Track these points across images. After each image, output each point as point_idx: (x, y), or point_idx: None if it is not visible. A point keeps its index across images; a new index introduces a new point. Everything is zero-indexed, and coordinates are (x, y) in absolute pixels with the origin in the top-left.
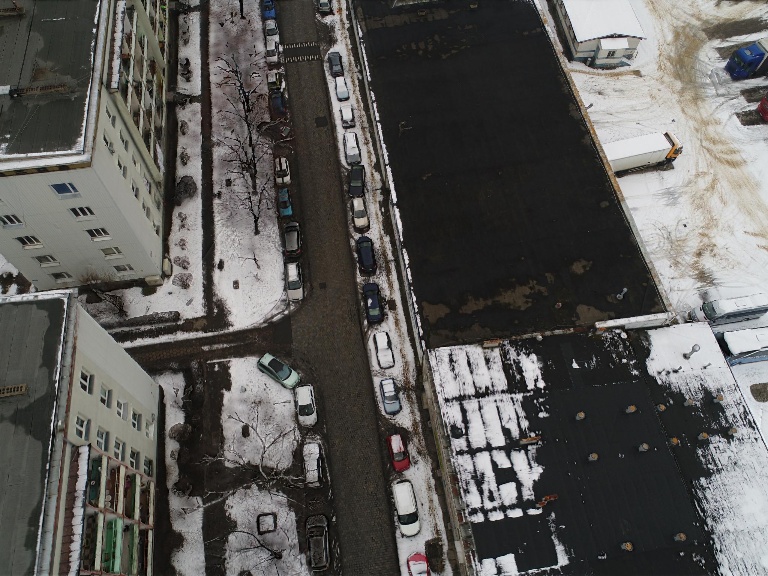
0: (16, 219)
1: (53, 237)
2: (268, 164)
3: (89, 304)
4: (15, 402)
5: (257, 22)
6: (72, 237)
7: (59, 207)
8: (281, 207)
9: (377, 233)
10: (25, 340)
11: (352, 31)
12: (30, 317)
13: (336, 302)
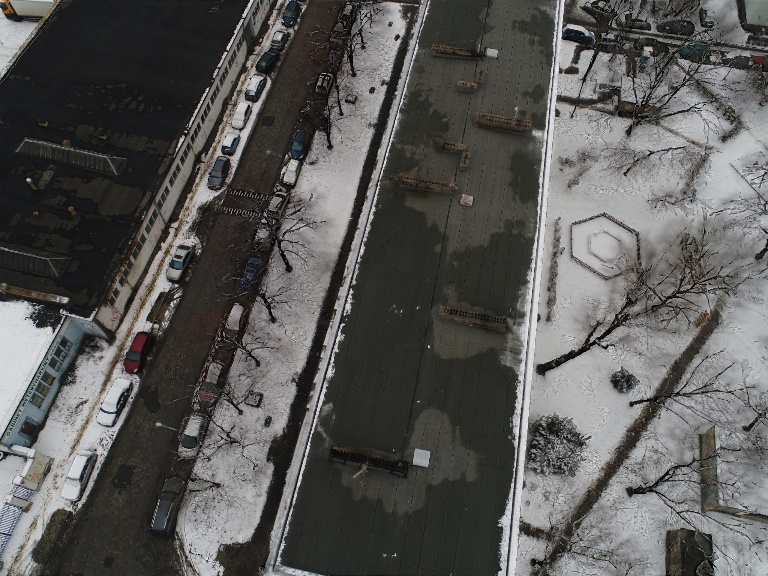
0: None
1: None
2: None
3: None
4: None
5: (275, 262)
6: None
7: None
8: (338, 55)
9: (275, 27)
10: None
11: (174, 215)
12: None
13: None
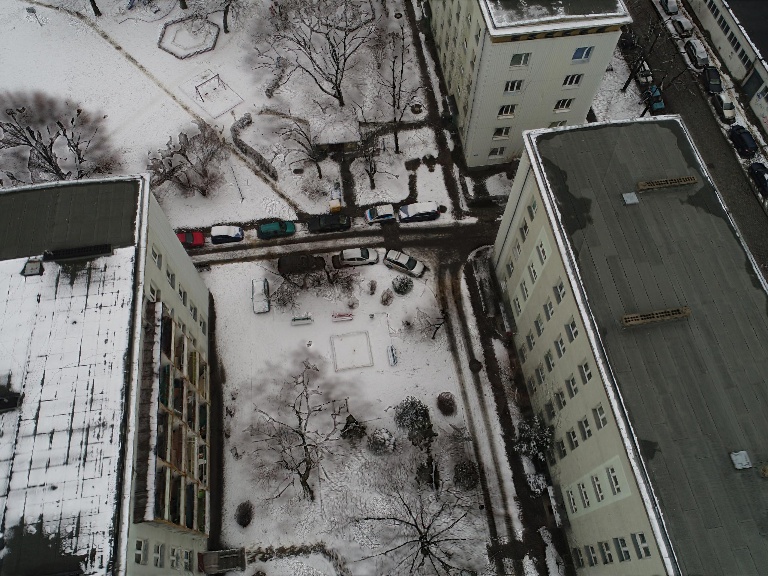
0: (517, 86)
1: (530, 107)
2: (624, 67)
3: (511, 180)
4: (685, 191)
5: None
6: (543, 107)
7: (563, 73)
8: None
9: (744, 124)
10: (665, 148)
11: None
12: (658, 133)
13: (728, 179)
